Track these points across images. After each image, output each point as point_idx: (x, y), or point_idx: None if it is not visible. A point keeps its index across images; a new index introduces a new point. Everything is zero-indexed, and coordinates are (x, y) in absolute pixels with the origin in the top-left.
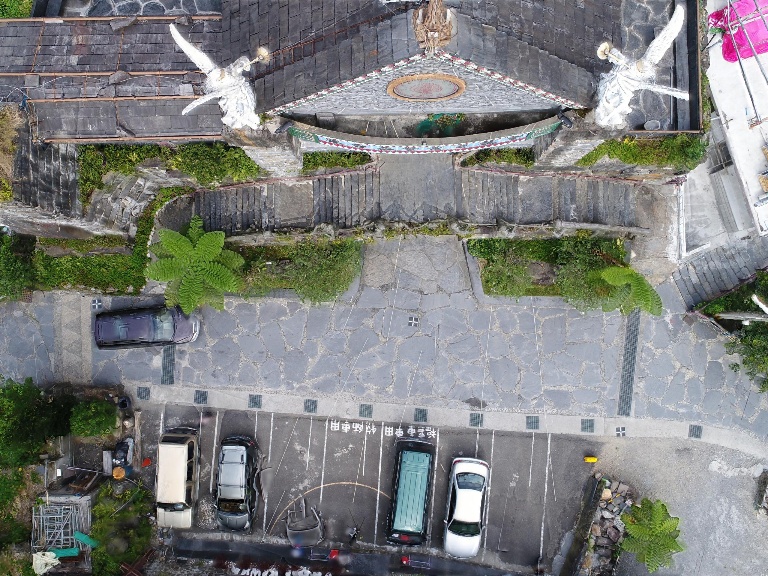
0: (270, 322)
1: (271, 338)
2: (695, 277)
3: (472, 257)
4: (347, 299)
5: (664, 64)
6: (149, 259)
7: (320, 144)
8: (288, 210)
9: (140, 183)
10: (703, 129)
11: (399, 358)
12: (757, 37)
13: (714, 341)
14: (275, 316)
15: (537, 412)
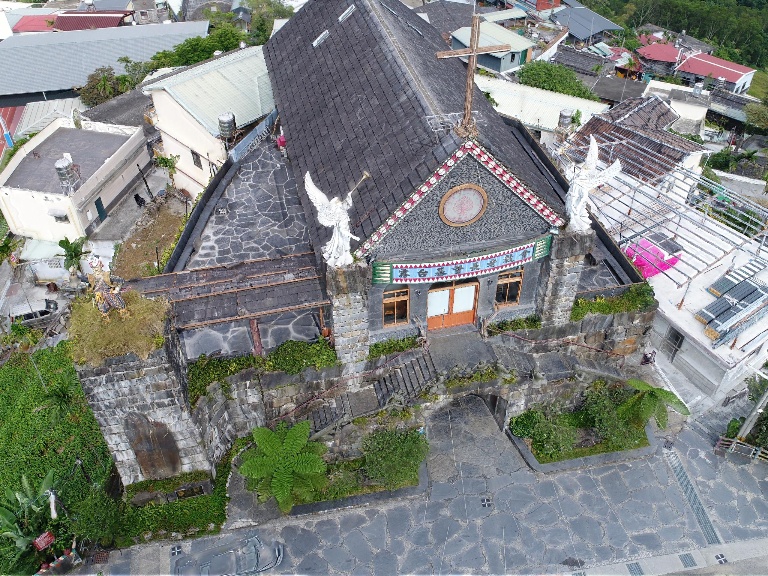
0: (352, 531)
1: (356, 545)
2: (705, 429)
3: (518, 438)
4: (420, 493)
5: (600, 258)
6: (228, 498)
7: (381, 331)
8: (357, 408)
9: (226, 418)
10: (645, 281)
11: (484, 537)
12: (651, 259)
13: (751, 465)
14: (356, 525)
15: (634, 558)
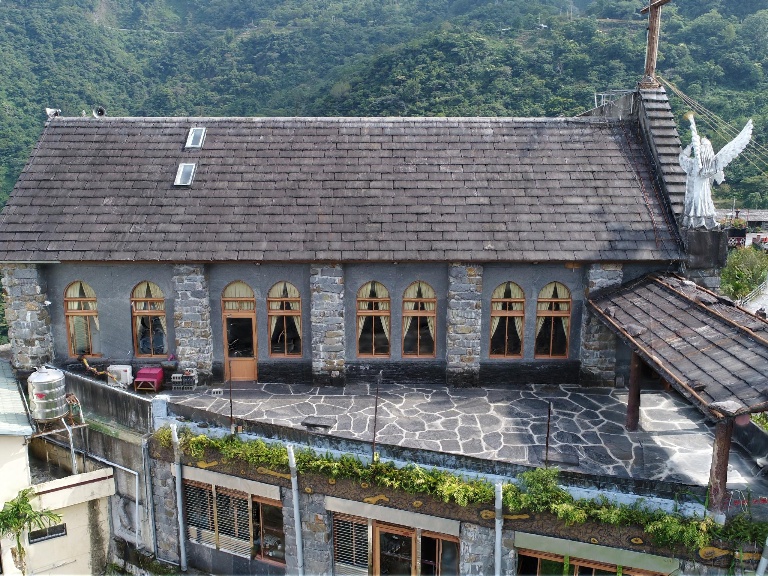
0: None
1: None
2: None
3: None
4: None
5: None
6: None
7: None
8: None
9: None
10: None
11: None
12: None
13: None
14: None
15: None
